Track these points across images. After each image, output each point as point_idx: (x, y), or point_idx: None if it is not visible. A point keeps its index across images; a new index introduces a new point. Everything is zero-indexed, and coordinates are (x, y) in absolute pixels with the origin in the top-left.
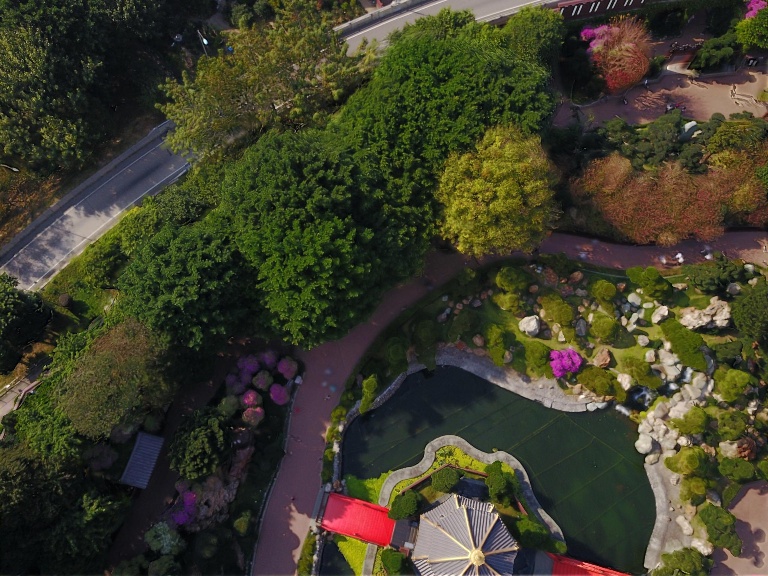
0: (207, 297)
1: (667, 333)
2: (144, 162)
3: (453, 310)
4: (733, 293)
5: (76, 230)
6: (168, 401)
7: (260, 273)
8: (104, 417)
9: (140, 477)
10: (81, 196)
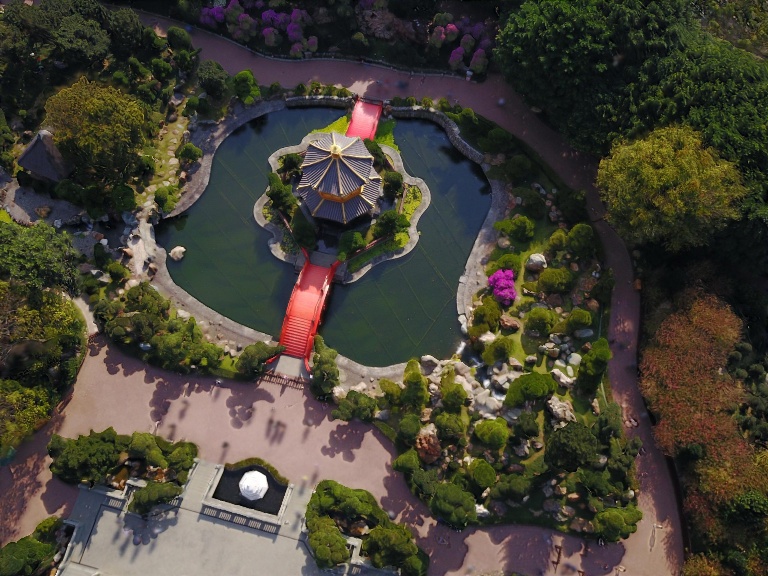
0: None
1: None
2: None
3: (544, 197)
4: None
5: None
6: None
7: None
8: None
9: None
10: None
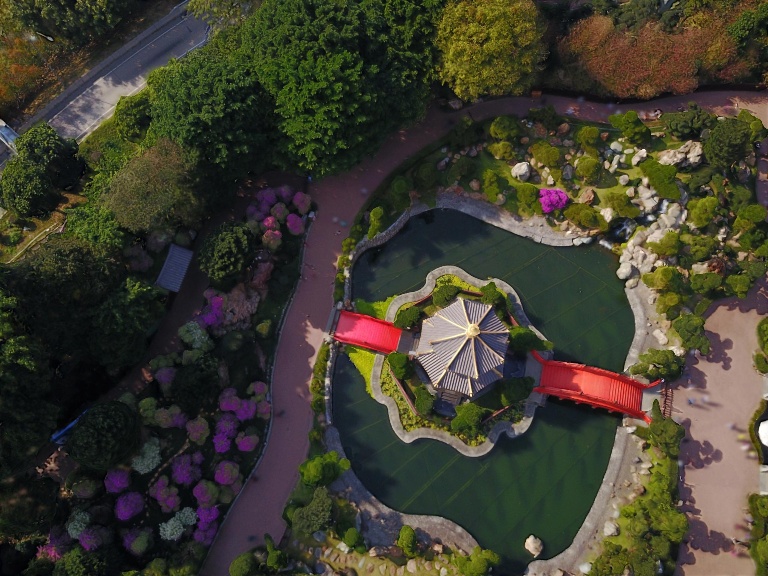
0: (231, 118)
1: (645, 170)
2: (166, 38)
3: (451, 160)
4: (706, 138)
5: (105, 98)
6: (196, 220)
7: (278, 99)
8: (144, 210)
9: (173, 282)
10: (109, 68)
